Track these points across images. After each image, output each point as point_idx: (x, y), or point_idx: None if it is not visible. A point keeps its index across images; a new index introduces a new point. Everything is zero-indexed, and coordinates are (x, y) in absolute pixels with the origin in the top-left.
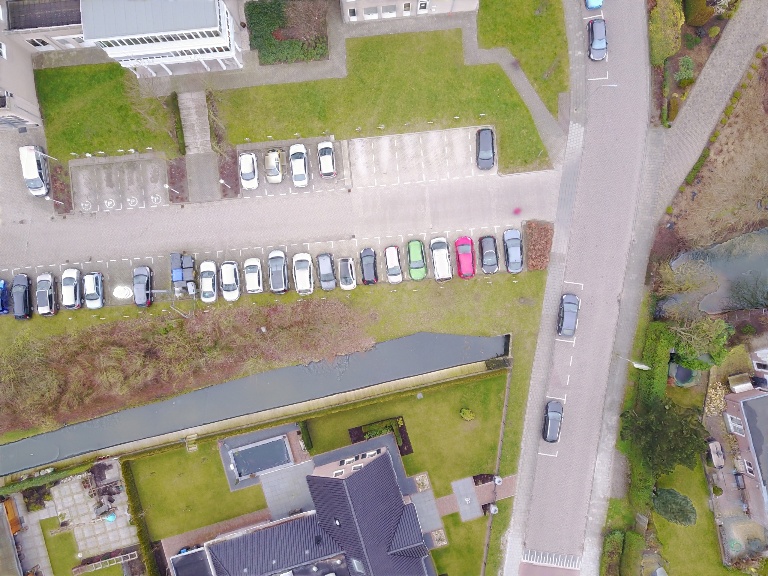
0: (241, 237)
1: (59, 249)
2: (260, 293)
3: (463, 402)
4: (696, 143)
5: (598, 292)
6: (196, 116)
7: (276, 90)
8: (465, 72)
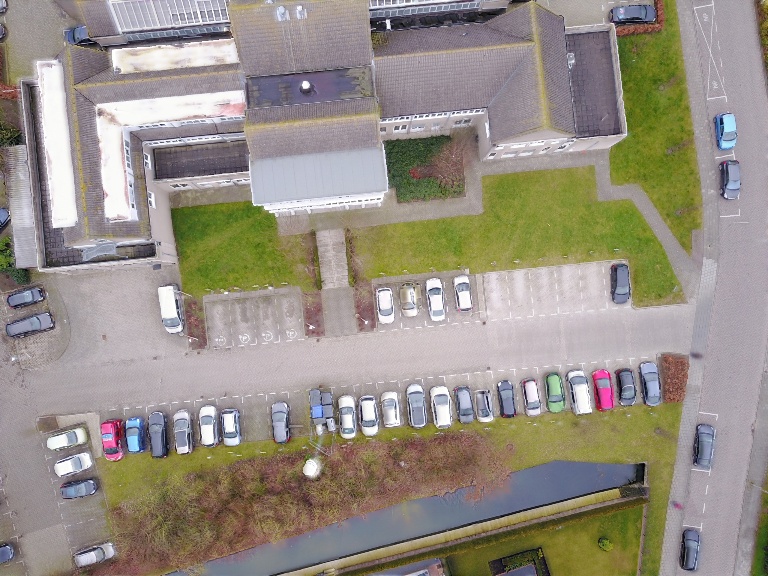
0: (377, 371)
1: (193, 385)
2: (397, 427)
3: (601, 532)
4: None
5: (732, 422)
6: (333, 252)
7: (414, 227)
8: (599, 208)
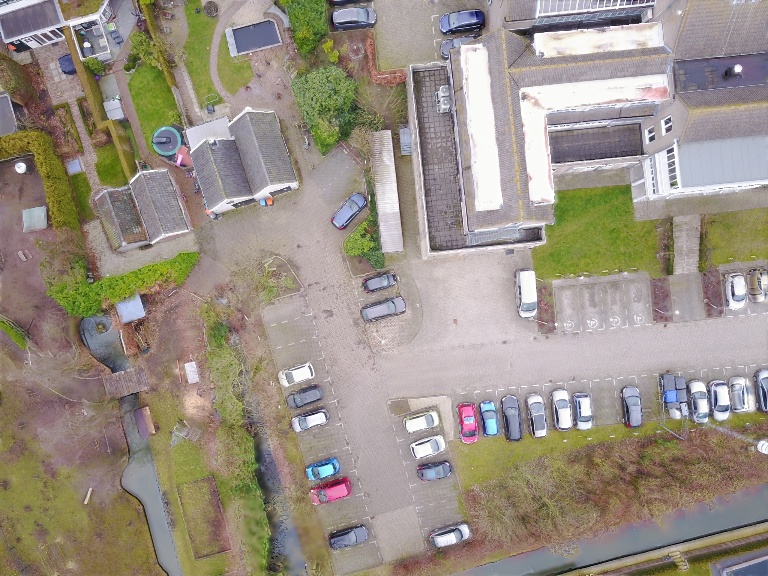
0: (725, 356)
1: (542, 369)
2: (746, 411)
3: None
4: None
5: None
6: (686, 238)
7: None
8: None
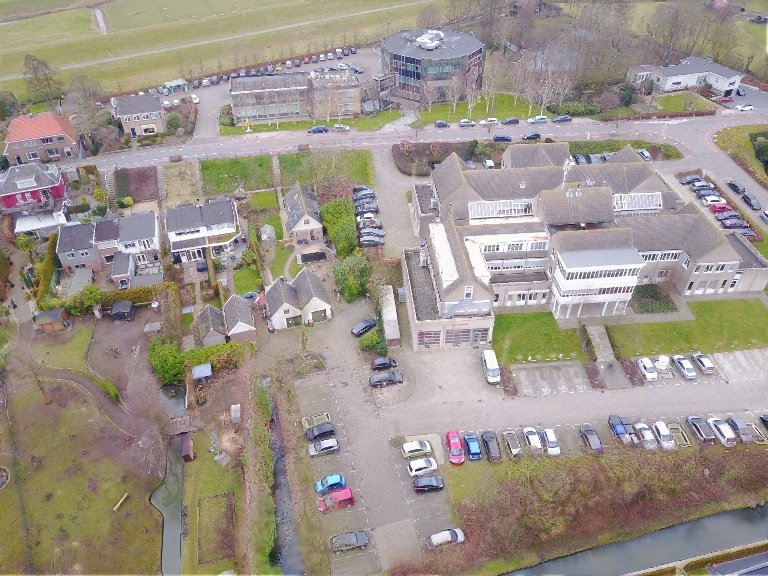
0: (657, 410)
1: (512, 418)
2: (690, 447)
3: None
4: None
5: None
6: (599, 339)
7: (651, 326)
8: None
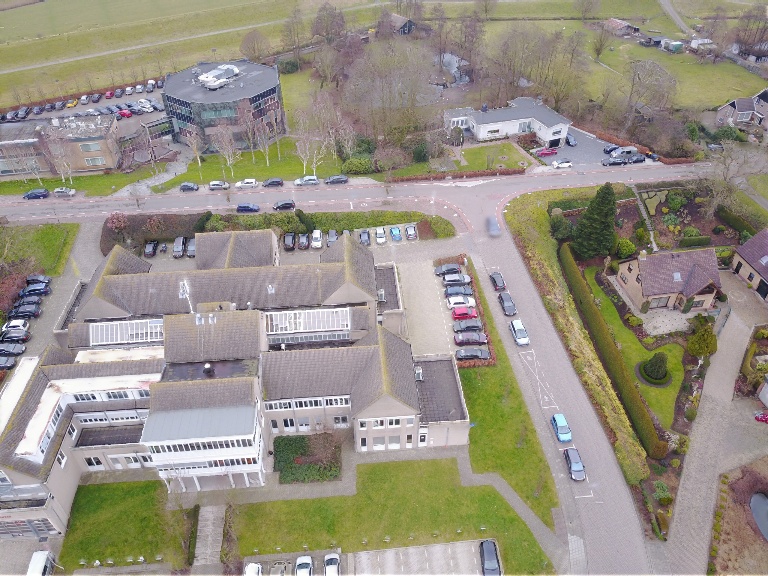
0: None
1: None
2: None
3: None
4: (698, 557)
5: None
6: (212, 527)
7: (291, 505)
8: (463, 492)
